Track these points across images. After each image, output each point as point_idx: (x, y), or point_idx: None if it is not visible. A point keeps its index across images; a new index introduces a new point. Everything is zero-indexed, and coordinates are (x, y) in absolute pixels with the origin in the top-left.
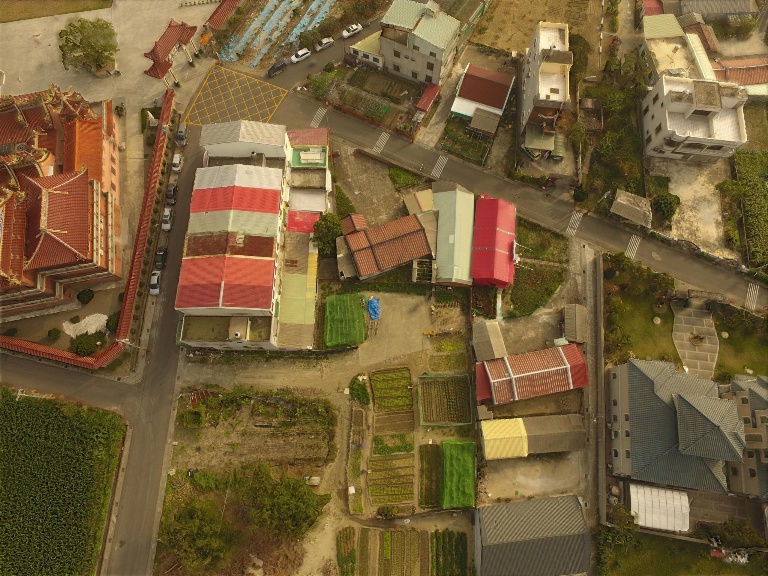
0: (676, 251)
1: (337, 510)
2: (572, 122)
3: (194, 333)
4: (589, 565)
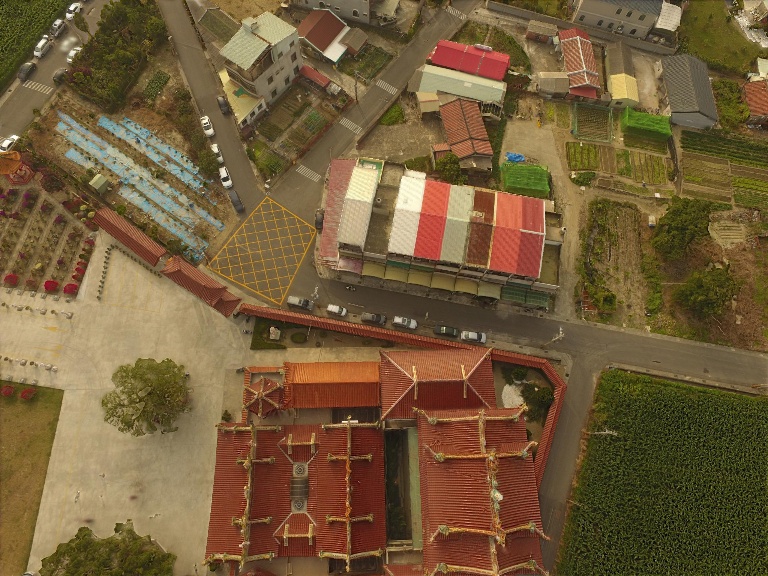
0: None
1: None
2: None
3: (549, 278)
4: (702, 62)
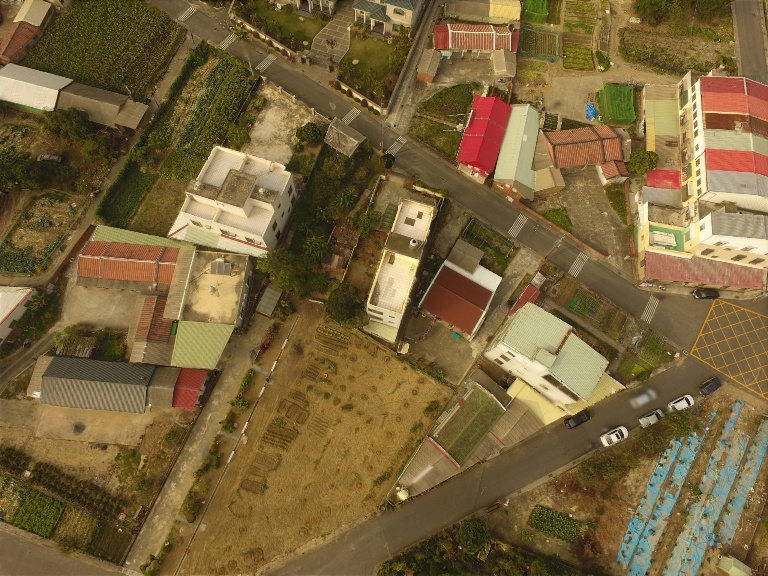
0: (313, 106)
1: (617, 6)
2: (362, 247)
3: None
4: None
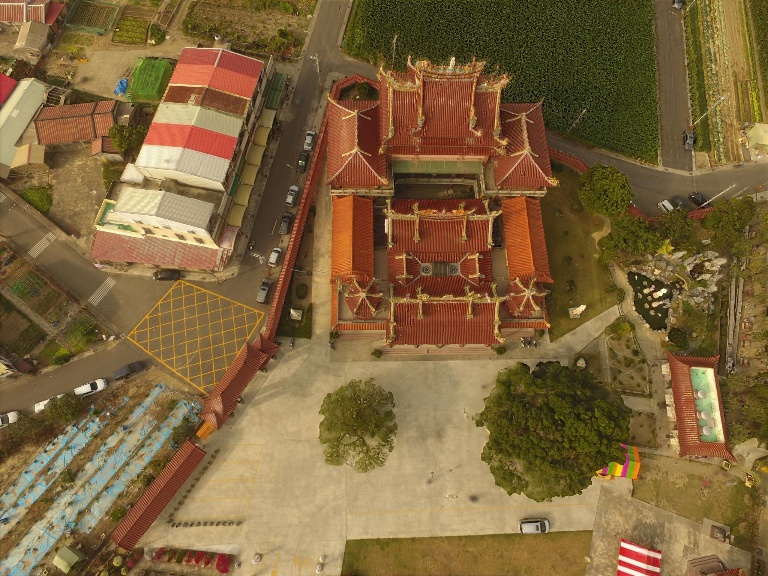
0: None
1: None
2: None
3: None
4: None
